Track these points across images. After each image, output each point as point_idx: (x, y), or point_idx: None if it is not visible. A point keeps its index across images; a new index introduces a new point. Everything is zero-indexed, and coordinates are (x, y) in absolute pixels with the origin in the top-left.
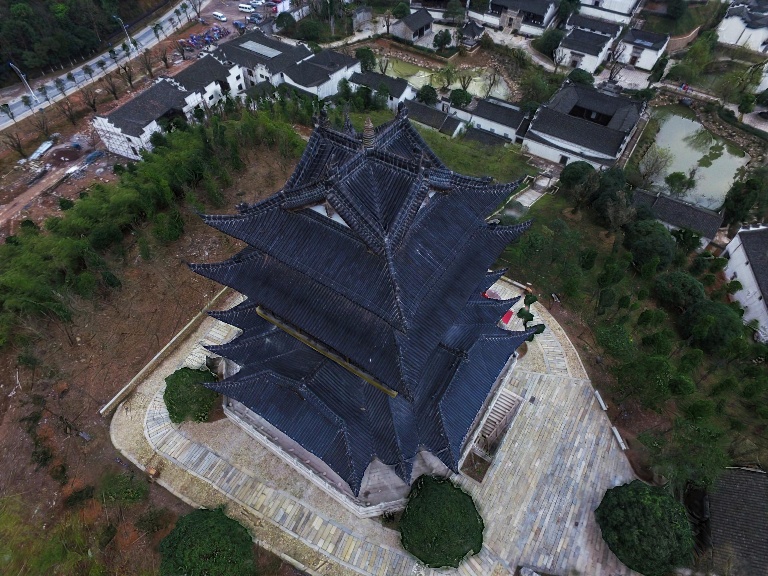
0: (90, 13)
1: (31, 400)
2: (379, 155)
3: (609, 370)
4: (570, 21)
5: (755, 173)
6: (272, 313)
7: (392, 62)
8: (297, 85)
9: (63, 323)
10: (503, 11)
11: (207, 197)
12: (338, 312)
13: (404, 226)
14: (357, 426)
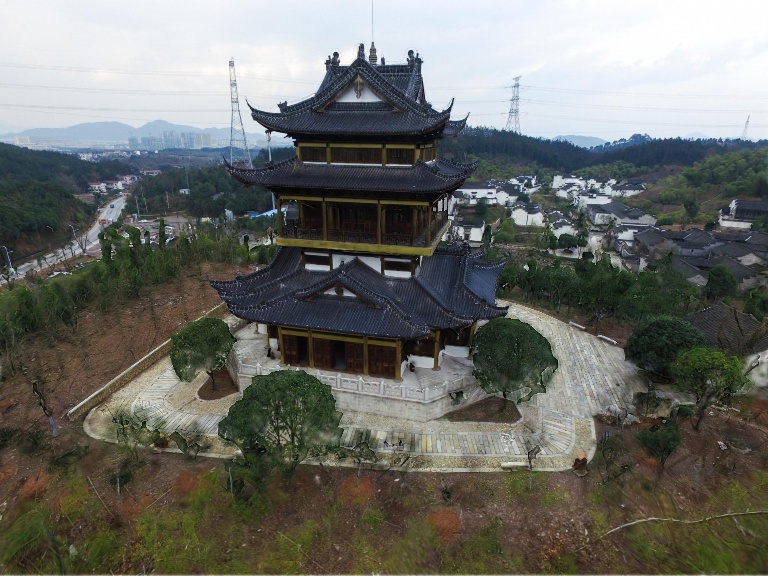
0: None
1: None
2: (381, 70)
3: (569, 317)
4: None
5: None
6: (295, 234)
7: None
8: None
9: (9, 347)
10: None
11: None
12: (372, 175)
13: None
14: None
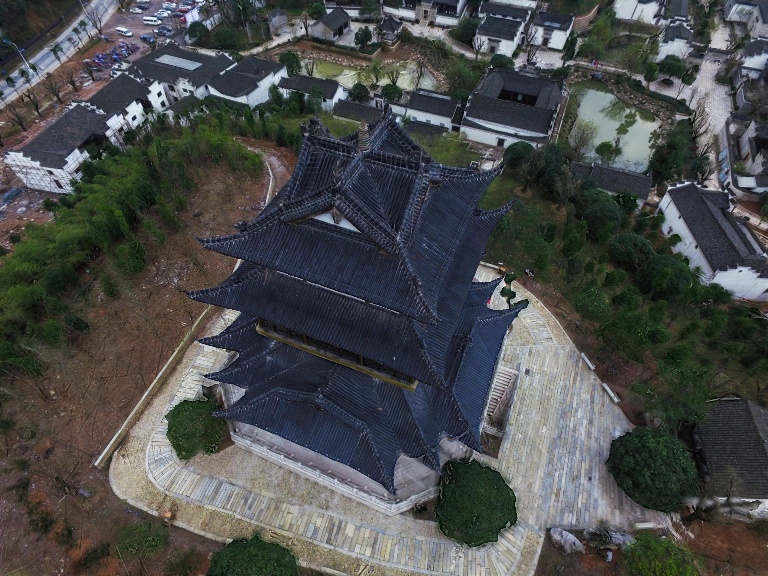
0: None
1: (10, 467)
2: (376, 157)
3: (588, 332)
4: (482, 9)
5: (668, 135)
6: (274, 329)
7: (315, 64)
8: (224, 96)
9: (33, 378)
10: (417, 4)
11: (163, 222)
12: (352, 317)
13: (411, 223)
14: (378, 426)
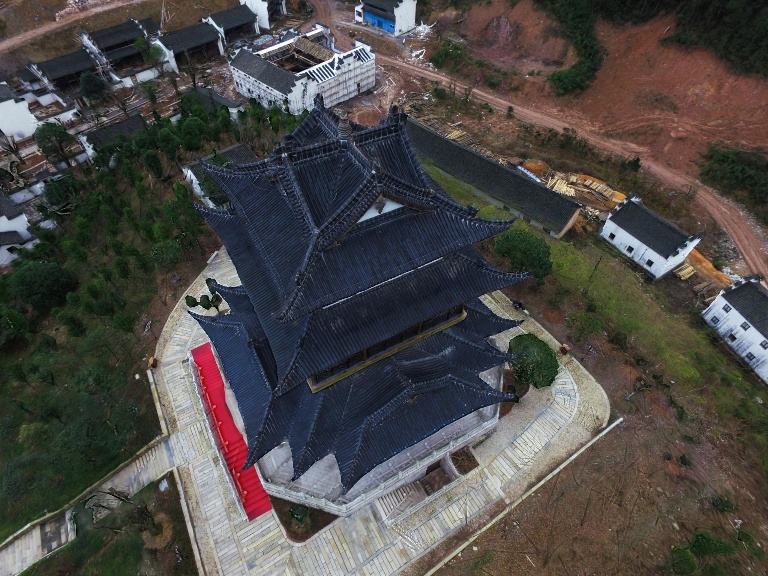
0: None
1: None
2: None
3: None
4: None
5: None
6: None
7: None
8: None
9: None
10: None
11: None
12: None
13: None
14: None
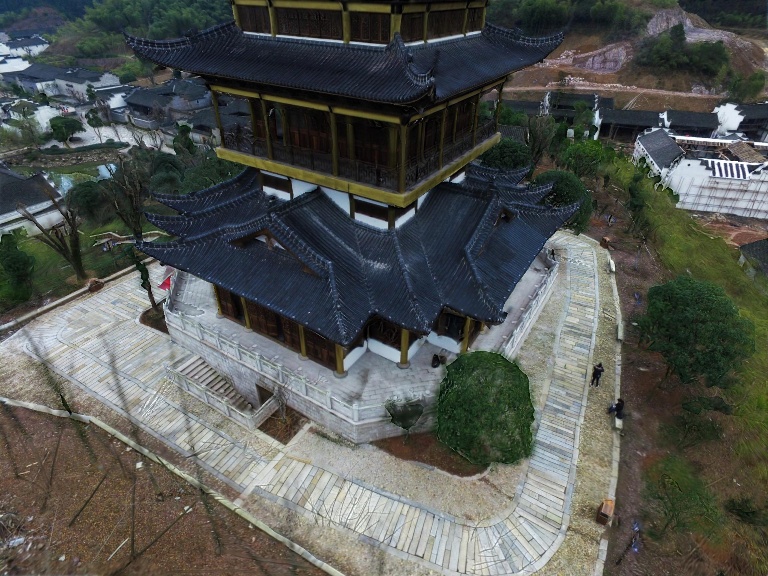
0: None
1: None
2: None
3: None
4: None
5: None
6: (416, 177)
7: None
8: None
9: None
10: None
11: None
12: (475, 53)
13: None
14: None
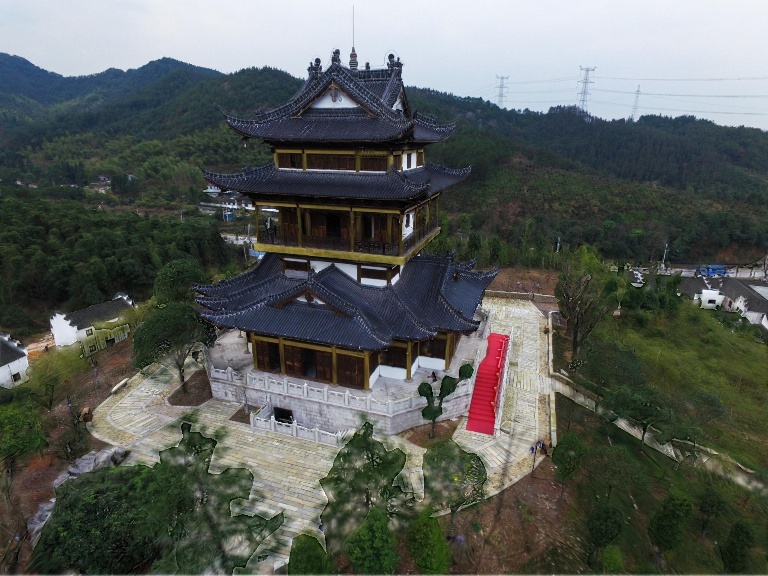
0: (657, 241)
1: None
2: None
3: (447, 567)
4: None
5: None
6: None
7: None
8: None
9: None
10: None
11: None
12: None
13: None
14: None
